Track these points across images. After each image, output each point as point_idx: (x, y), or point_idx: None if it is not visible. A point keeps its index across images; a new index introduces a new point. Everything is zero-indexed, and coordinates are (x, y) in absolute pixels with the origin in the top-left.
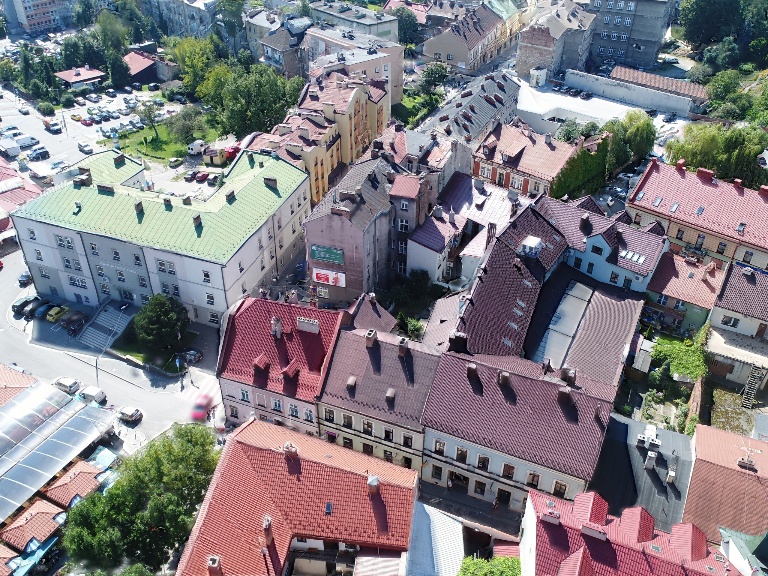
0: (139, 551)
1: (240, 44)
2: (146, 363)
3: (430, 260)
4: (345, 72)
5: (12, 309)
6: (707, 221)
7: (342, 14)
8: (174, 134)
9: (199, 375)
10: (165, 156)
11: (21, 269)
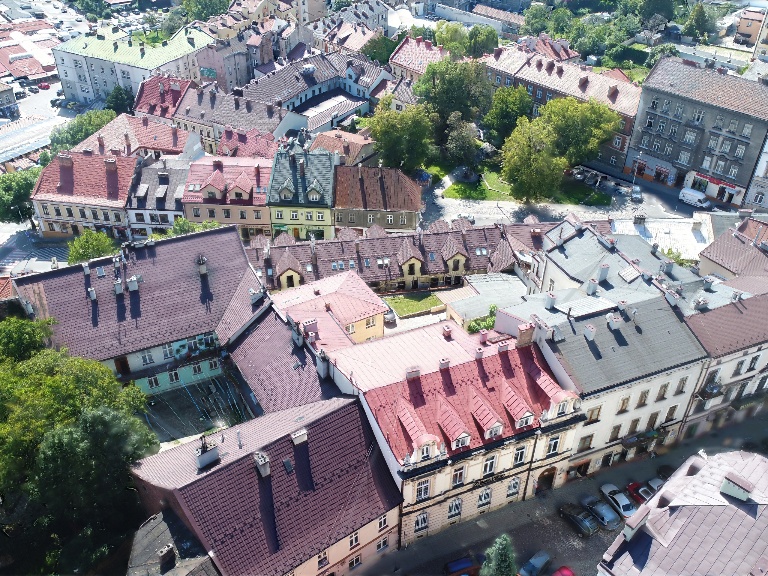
0: None
1: None
2: None
3: None
4: None
5: (51, 102)
6: (422, 68)
7: None
8: (164, 31)
9: None
10: None
11: None
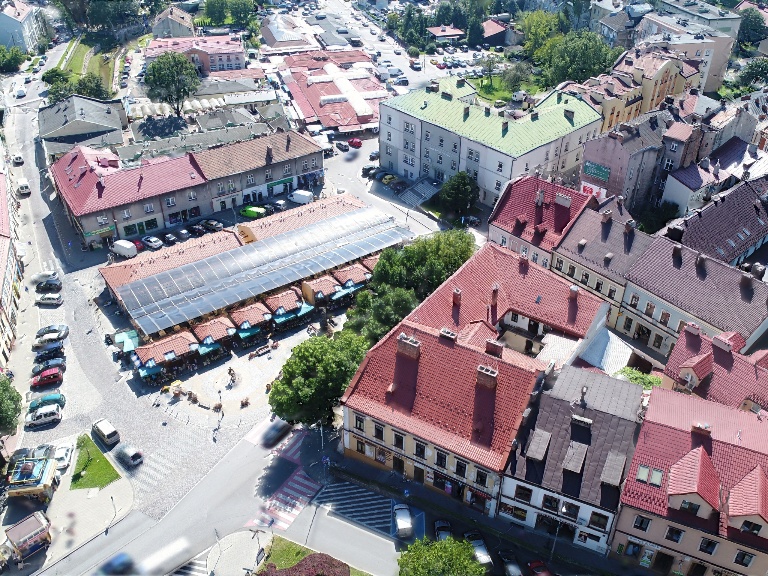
0: (413, 288)
1: (582, 24)
2: (441, 218)
3: (683, 195)
4: (666, 49)
5: (362, 170)
6: None
7: (686, 8)
8: (505, 82)
9: (475, 233)
10: (493, 98)
11: (373, 150)
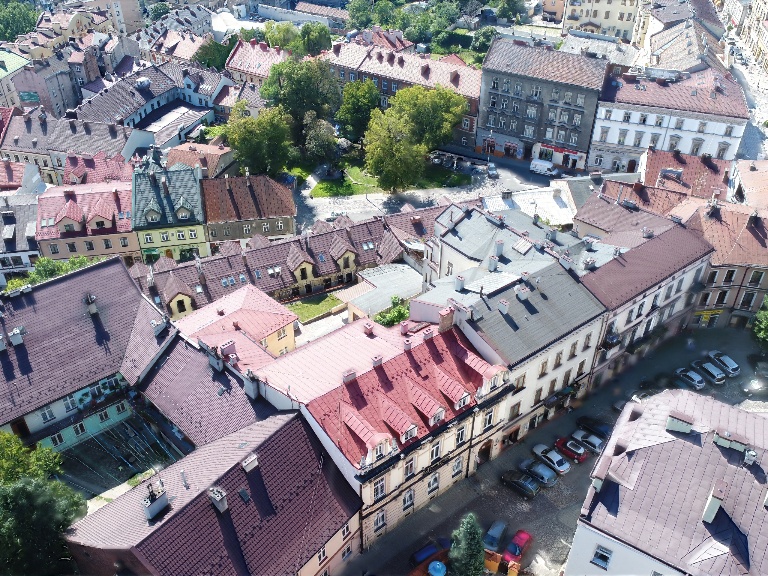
0: None
1: None
2: None
3: None
4: None
5: None
6: (261, 70)
7: None
8: None
9: None
10: None
11: None
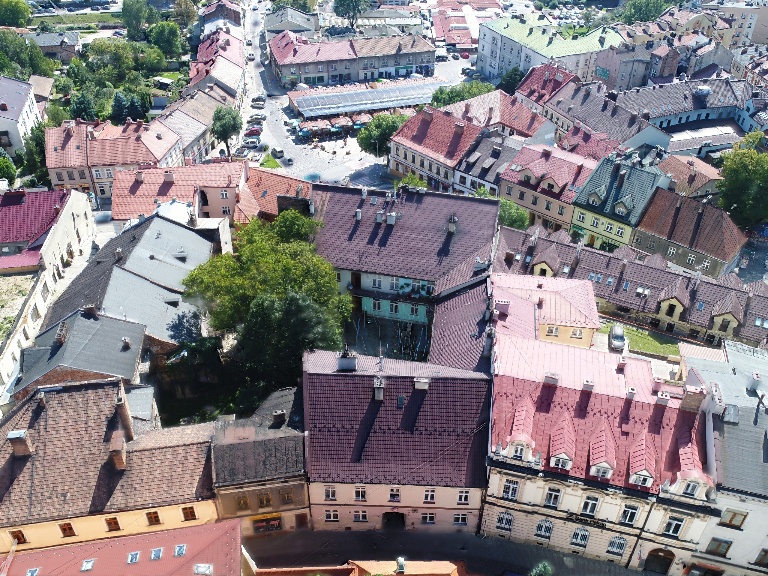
0: None
1: None
2: None
3: None
4: None
5: (462, 70)
6: None
7: None
8: None
9: None
10: None
11: None
